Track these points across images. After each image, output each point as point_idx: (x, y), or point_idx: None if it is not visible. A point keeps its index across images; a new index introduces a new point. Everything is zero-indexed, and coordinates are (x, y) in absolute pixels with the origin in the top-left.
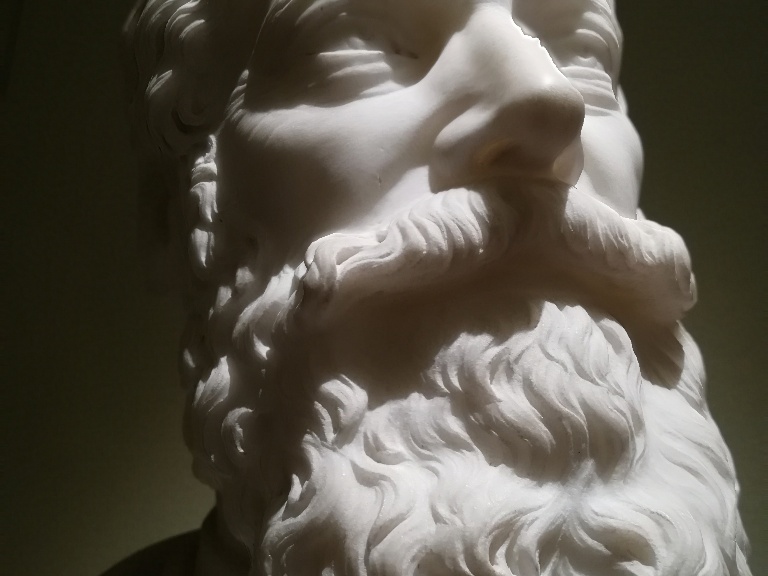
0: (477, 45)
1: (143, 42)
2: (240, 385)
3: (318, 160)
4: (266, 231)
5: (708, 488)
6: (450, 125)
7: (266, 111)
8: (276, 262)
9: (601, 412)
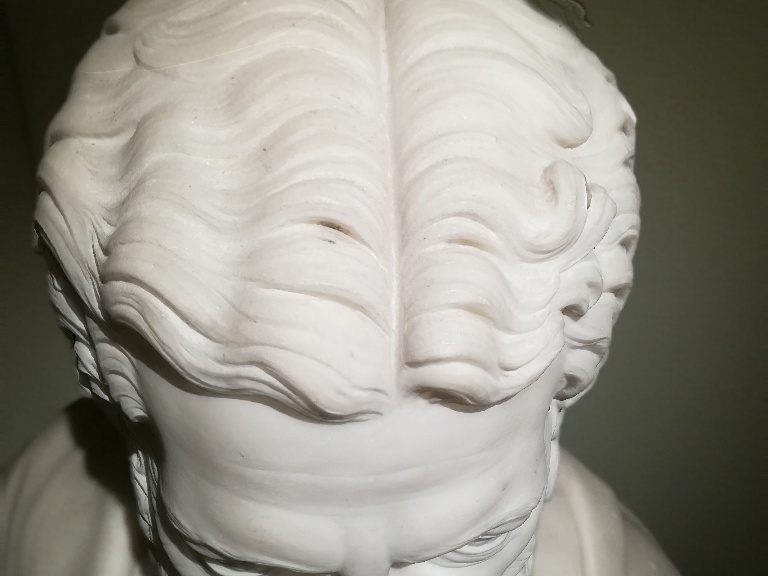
0: None
1: None
2: None
3: None
4: None
5: None
6: None
7: (172, 542)
8: None
9: None
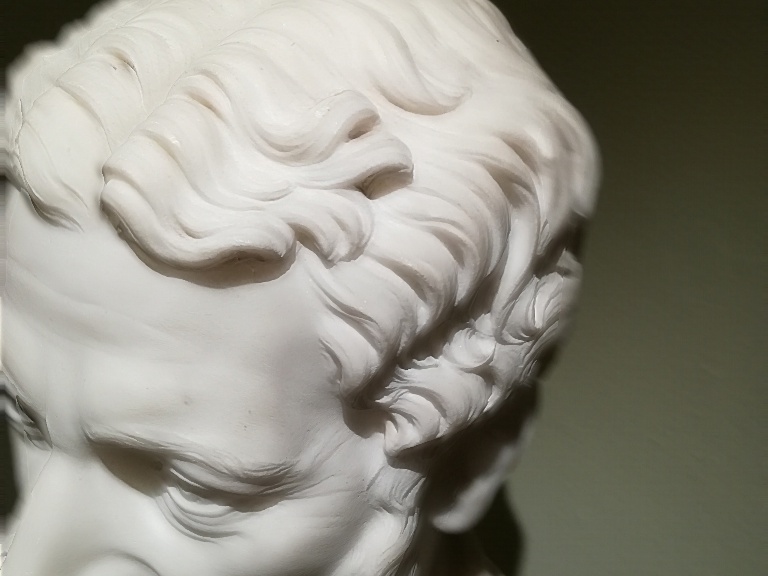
0: None
1: None
2: None
3: None
4: None
5: None
6: None
7: None
8: None
9: None
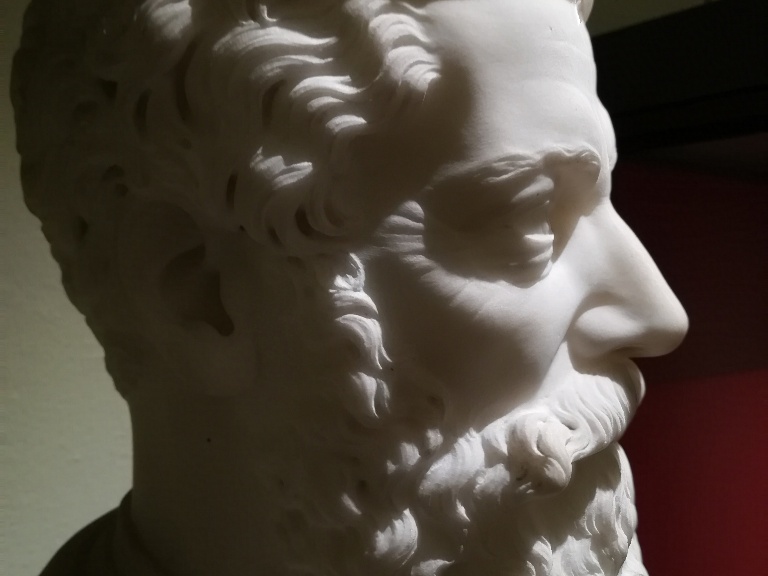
0: (615, 248)
1: (241, 89)
2: (425, 536)
3: (517, 341)
4: (449, 392)
5: (634, 541)
6: (591, 314)
7: (467, 277)
8: (458, 423)
9: None
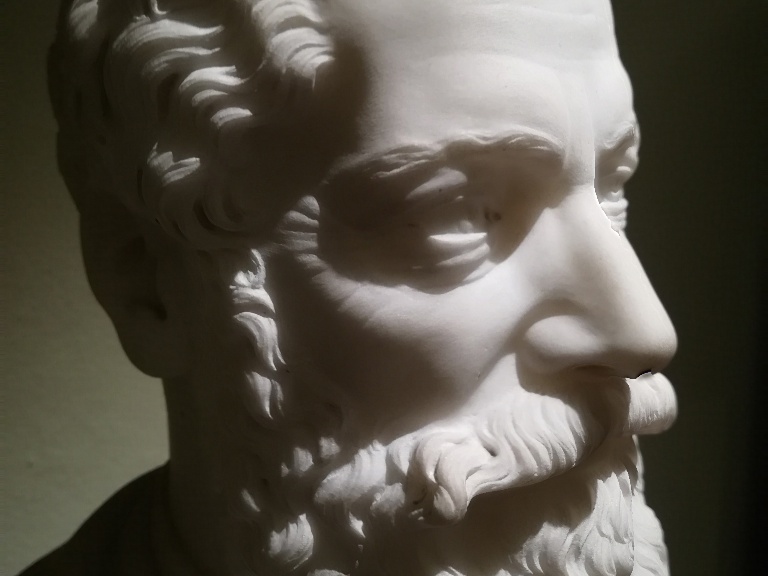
0: (580, 248)
1: (135, 86)
2: (323, 543)
3: (423, 353)
4: (349, 400)
5: None
6: (545, 324)
7: (359, 281)
8: (361, 433)
9: (626, 566)
